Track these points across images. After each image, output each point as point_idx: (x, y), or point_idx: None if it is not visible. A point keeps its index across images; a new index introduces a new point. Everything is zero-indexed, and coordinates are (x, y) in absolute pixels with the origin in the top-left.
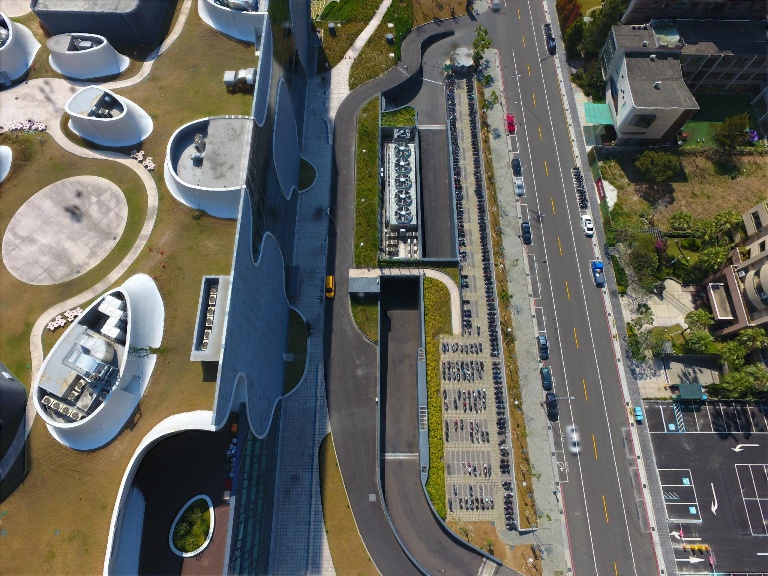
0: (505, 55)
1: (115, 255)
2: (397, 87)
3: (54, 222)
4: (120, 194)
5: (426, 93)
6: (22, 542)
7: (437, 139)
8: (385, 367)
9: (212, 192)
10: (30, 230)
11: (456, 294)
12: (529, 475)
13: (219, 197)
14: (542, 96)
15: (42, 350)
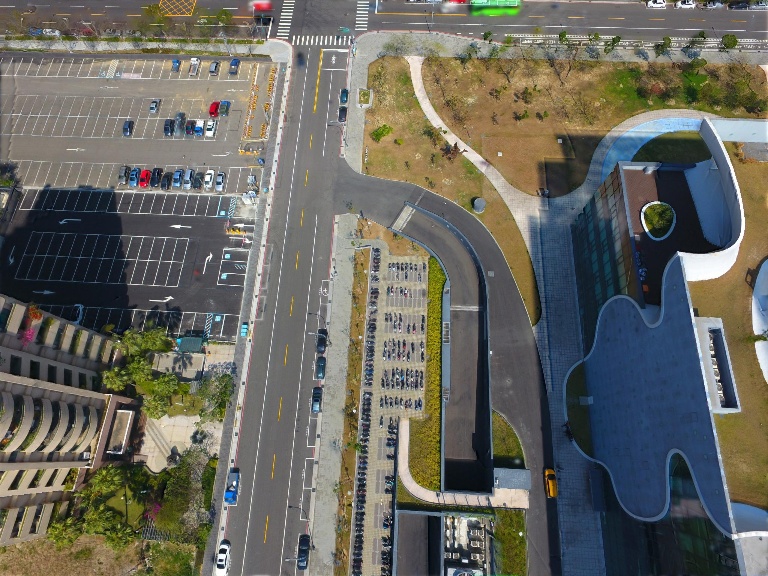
0: None
1: None
2: None
3: None
4: None
5: None
6: None
7: None
8: (479, 392)
9: None
10: None
11: (402, 467)
12: None
13: (761, 527)
14: None
15: None
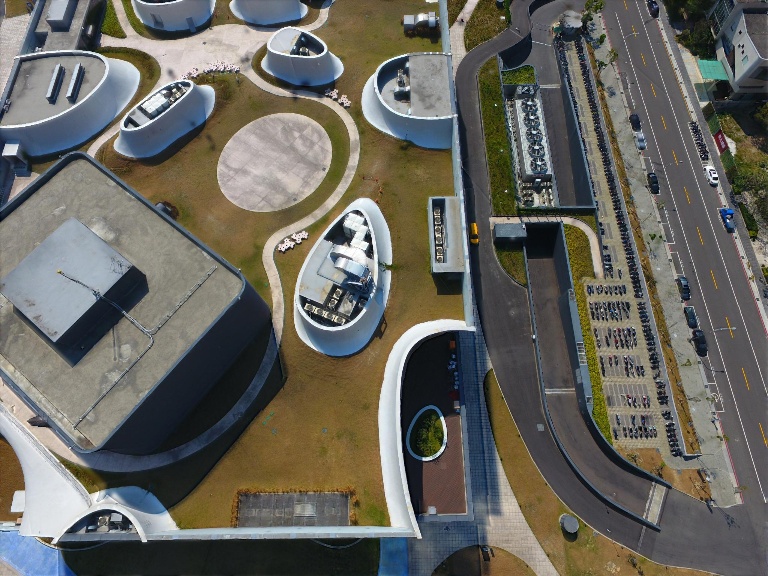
0: (609, 18)
1: (328, 184)
2: (513, 48)
3: (263, 155)
4: (321, 129)
5: (537, 54)
6: (293, 440)
7: (553, 97)
8: None
9: (425, 121)
10: (241, 163)
11: (594, 240)
12: (696, 402)
13: (429, 127)
14: (650, 56)
15: (277, 270)
